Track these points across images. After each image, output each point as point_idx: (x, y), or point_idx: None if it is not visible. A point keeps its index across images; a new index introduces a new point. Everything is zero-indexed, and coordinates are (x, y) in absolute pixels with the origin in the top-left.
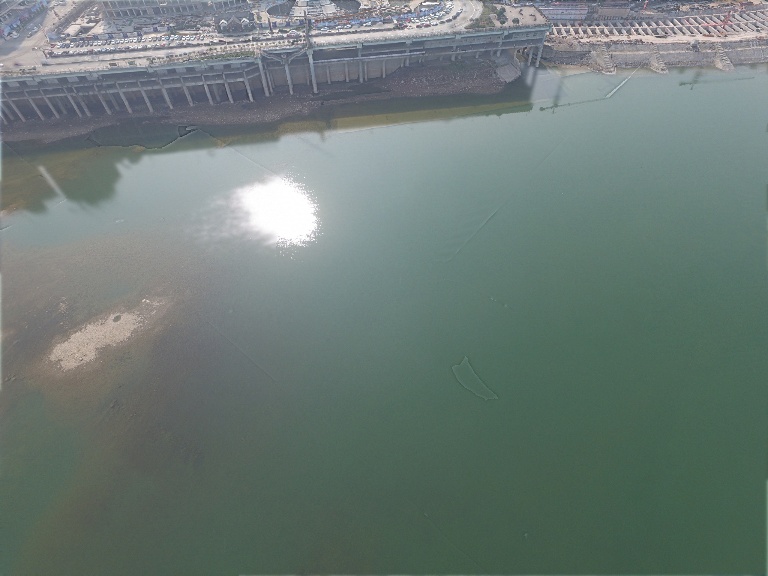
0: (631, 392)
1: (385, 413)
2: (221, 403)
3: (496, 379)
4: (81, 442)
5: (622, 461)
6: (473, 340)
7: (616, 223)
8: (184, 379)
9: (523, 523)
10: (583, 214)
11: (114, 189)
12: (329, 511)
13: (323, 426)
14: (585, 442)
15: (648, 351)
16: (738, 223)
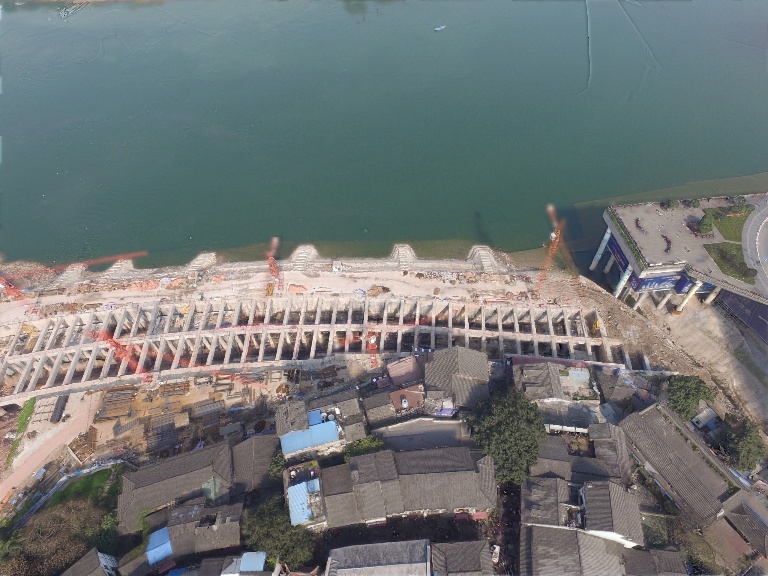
0: (544, 38)
1: (655, 47)
2: (739, 33)
3: None
4: None
5: (553, 26)
6: None
7: None
8: (767, 38)
9: None
10: None
11: None
12: (667, 18)
13: (683, 42)
14: (566, 30)
15: (531, 48)
16: (446, 88)
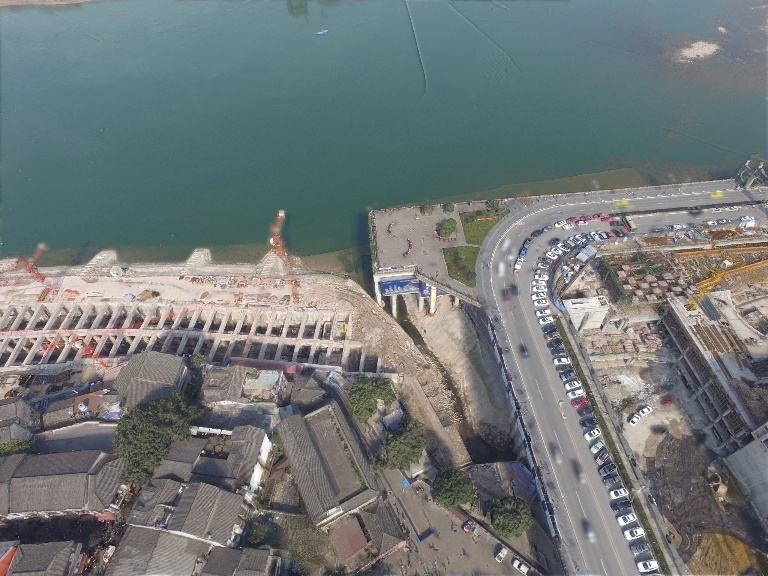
0: None
1: (532, 50)
2: (611, 36)
3: None
4: None
5: None
6: None
7: None
8: None
9: None
10: (408, 98)
11: None
12: (548, 21)
13: None
14: None
15: (404, 51)
16: (304, 92)
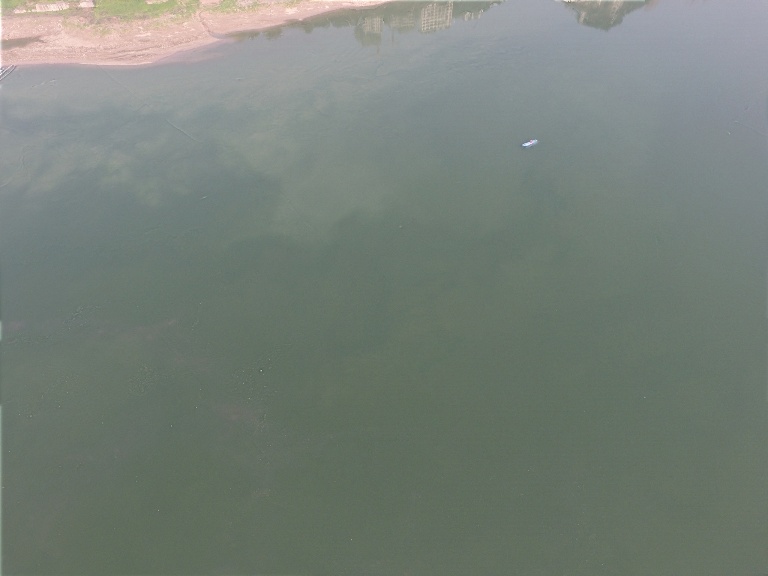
0: (684, 169)
1: None
2: None
3: None
4: None
5: (689, 144)
6: None
7: (705, 295)
8: None
9: None
10: (748, 305)
11: None
12: None
13: None
14: (710, 153)
15: (671, 189)
16: (569, 282)
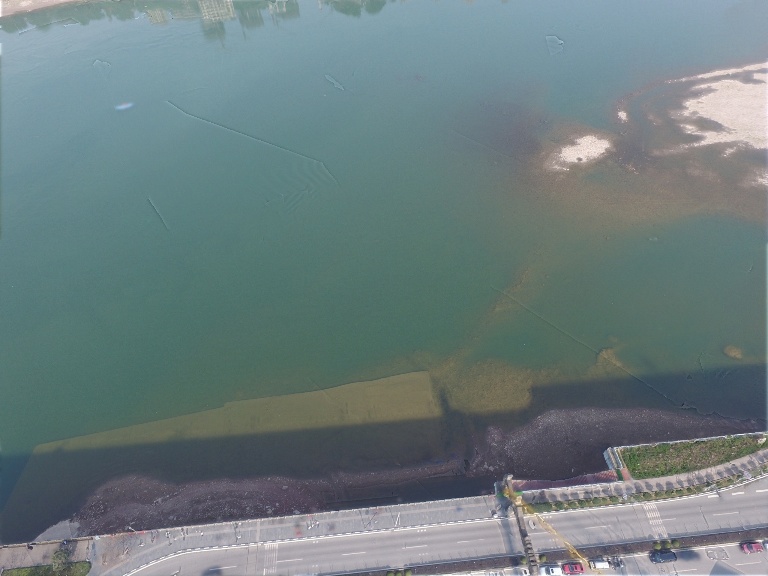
0: (241, 123)
1: (385, 135)
2: (481, 122)
3: (316, 128)
4: (552, 111)
5: (268, 103)
6: (322, 148)
7: (151, 217)
8: (509, 131)
9: (325, 98)
10: None
11: (704, 286)
12: (414, 94)
13: (421, 129)
14: (281, 111)
15: None
16: (45, 209)
